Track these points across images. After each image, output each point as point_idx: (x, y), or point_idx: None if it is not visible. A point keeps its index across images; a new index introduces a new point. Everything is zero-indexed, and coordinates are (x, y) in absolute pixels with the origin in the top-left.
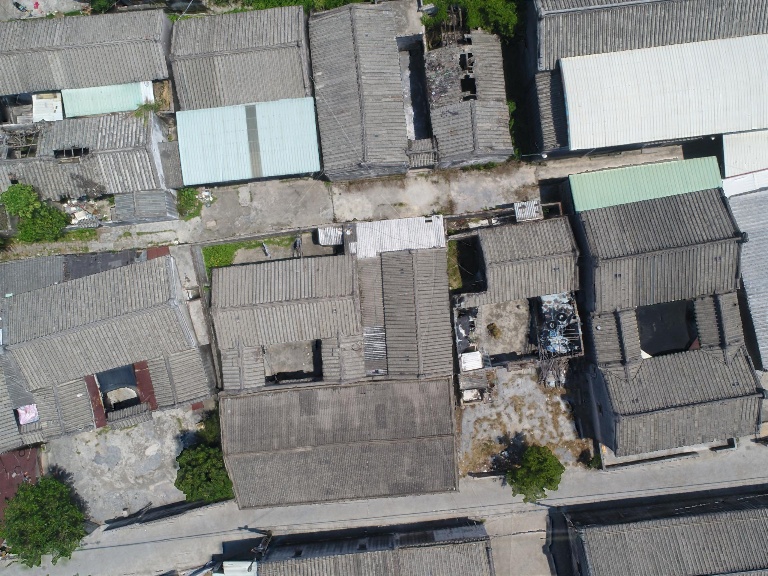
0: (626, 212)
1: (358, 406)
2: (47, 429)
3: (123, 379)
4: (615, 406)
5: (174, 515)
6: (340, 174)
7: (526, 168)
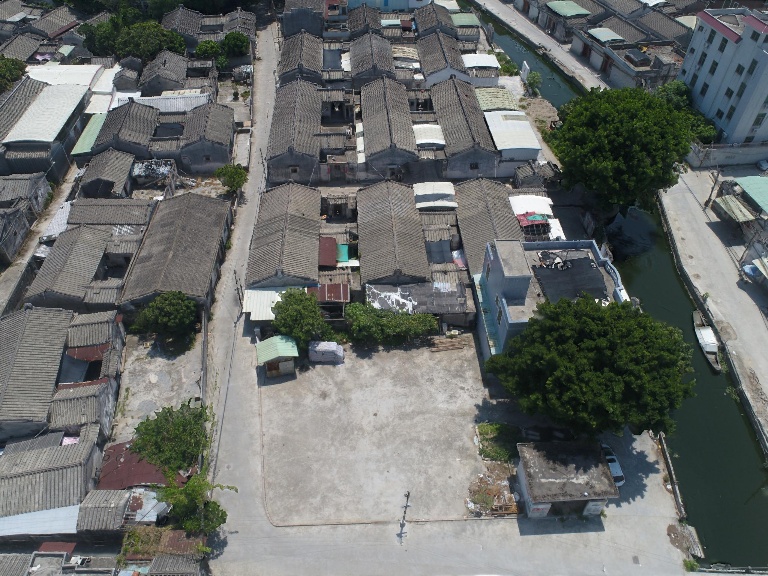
0: (101, 135)
1: (157, 235)
2: (88, 416)
3: (78, 374)
4: (197, 140)
5: (201, 345)
6: (4, 238)
7: (63, 186)
